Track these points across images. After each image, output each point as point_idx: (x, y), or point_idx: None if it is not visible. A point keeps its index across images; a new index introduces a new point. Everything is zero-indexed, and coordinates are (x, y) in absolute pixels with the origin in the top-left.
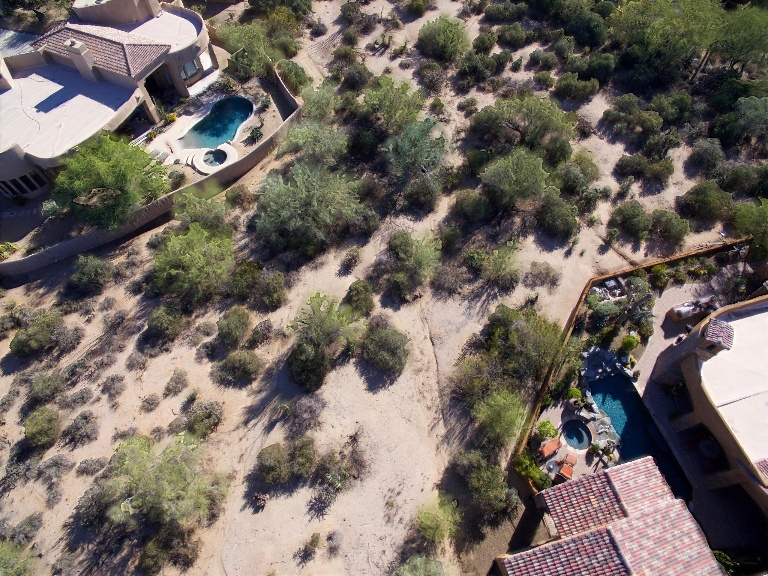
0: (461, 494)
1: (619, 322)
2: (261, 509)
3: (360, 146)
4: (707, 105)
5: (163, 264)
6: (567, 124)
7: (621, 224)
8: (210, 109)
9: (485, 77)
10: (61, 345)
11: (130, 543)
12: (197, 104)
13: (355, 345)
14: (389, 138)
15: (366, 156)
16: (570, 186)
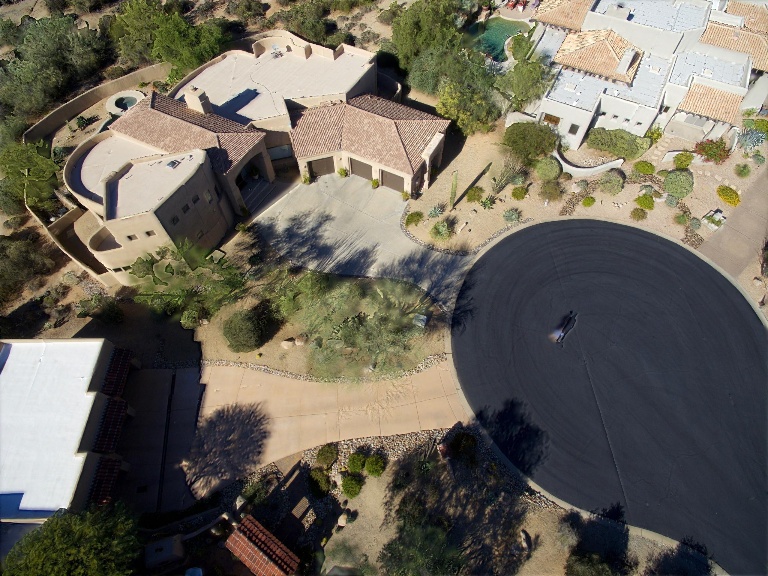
0: None
1: None
2: None
3: None
4: None
5: None
6: None
7: None
8: None
9: None
10: None
11: None
12: None
13: None
14: None
15: None
16: None
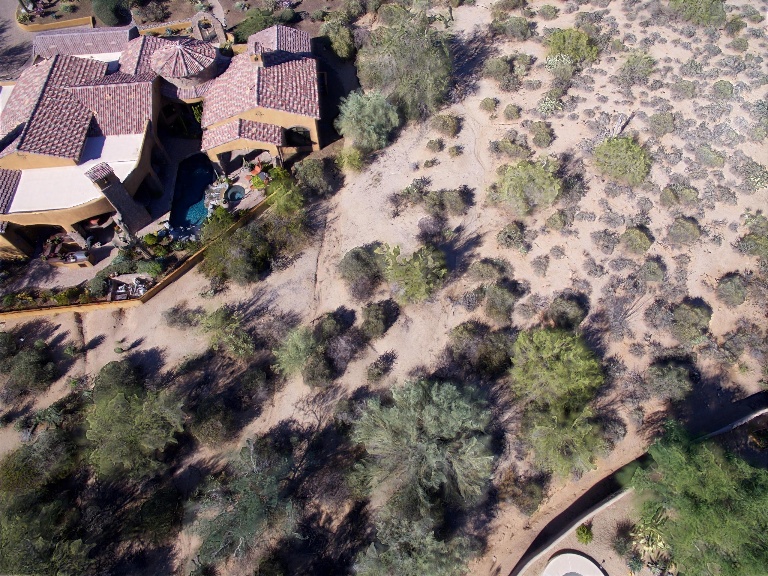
0: (330, 180)
1: None
2: None
3: None
4: None
5: None
6: None
7: None
8: None
9: None
10: None
11: None
12: None
13: None
14: None
15: (327, 575)
16: (66, 433)
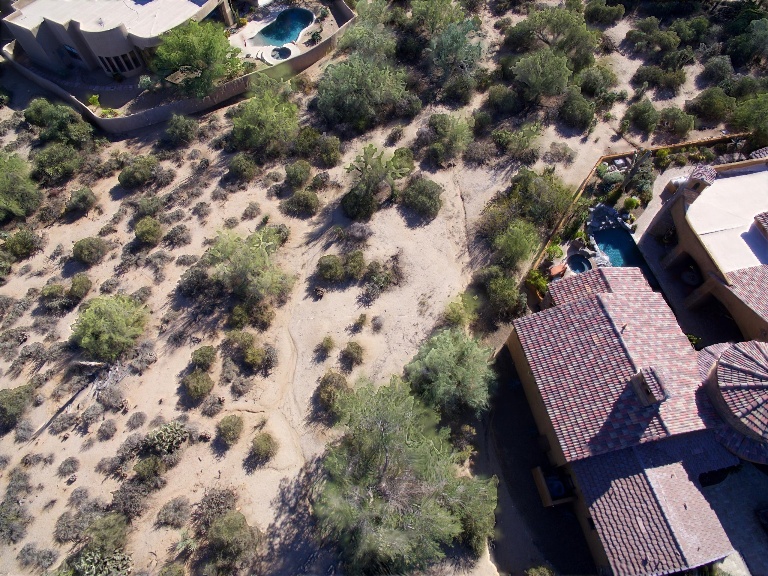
0: (480, 301)
1: (623, 185)
2: (320, 298)
3: (406, 51)
4: (722, 28)
5: (241, 124)
6: (592, 35)
7: (633, 120)
8: (276, 17)
9: (521, 2)
10: (159, 179)
11: (219, 310)
12: (265, 12)
13: (398, 193)
14: (432, 46)
15: (411, 60)
16: (590, 88)
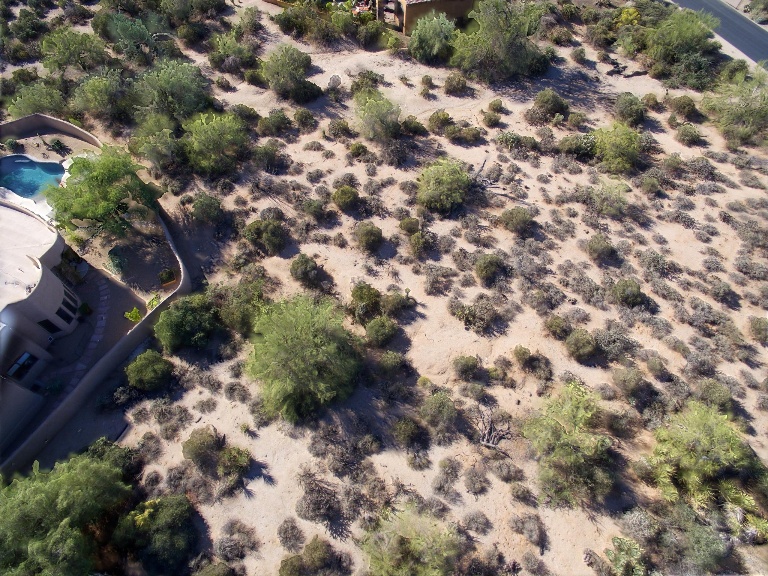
0: (378, 45)
1: None
2: None
3: None
4: None
5: None
6: None
7: None
8: None
9: None
10: (279, 212)
11: None
12: None
13: None
14: None
15: None
16: None
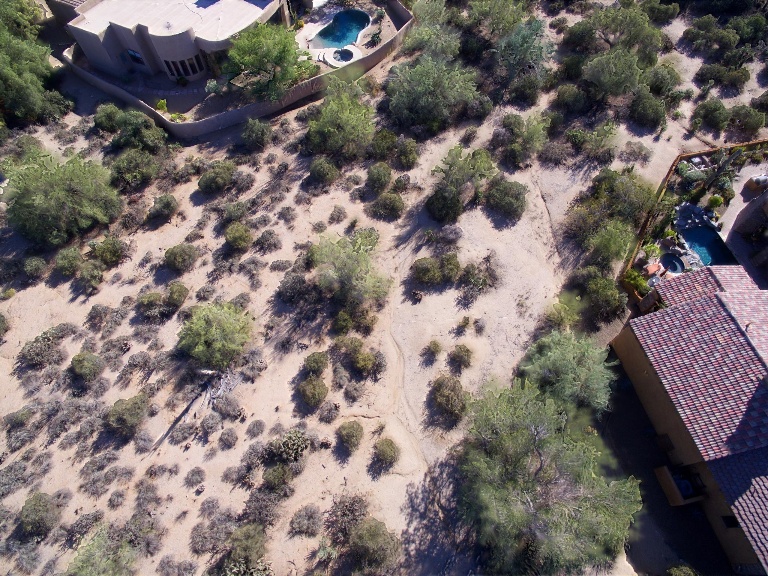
0: (577, 301)
1: (707, 184)
2: (418, 302)
3: (467, 52)
4: None
5: (318, 127)
6: None
7: (703, 118)
8: (332, 18)
9: (573, 1)
10: (241, 184)
11: (321, 315)
12: (321, 13)
13: (482, 195)
14: (492, 46)
15: (472, 61)
16: (657, 87)
